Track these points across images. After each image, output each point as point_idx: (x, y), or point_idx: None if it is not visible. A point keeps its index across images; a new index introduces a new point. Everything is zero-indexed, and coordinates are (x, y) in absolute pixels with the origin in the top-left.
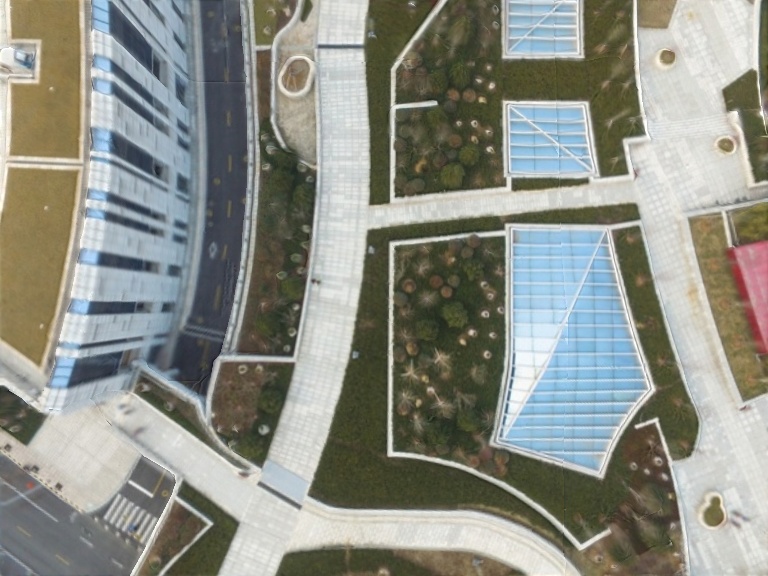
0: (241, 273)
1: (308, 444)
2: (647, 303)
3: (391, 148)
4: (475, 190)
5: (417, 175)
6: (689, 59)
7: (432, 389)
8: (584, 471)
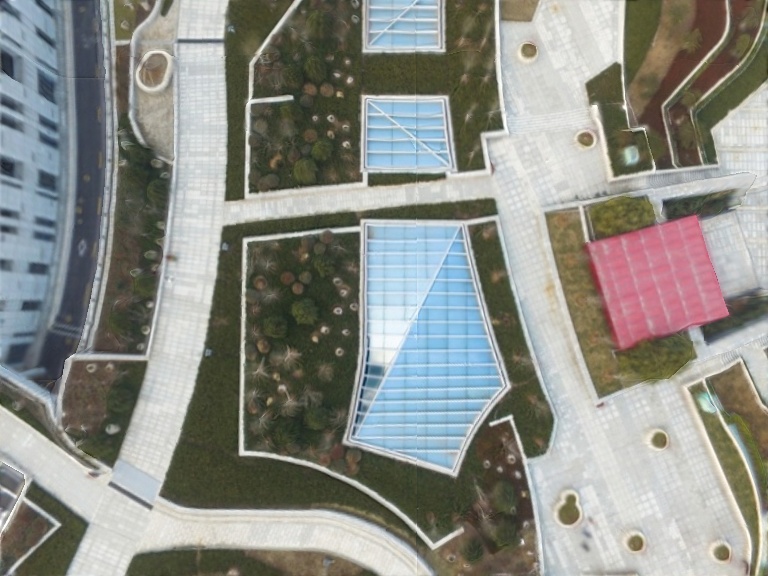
0: (98, 270)
1: (160, 443)
2: (502, 299)
3: (246, 143)
4: (331, 185)
5: (271, 170)
6: (553, 53)
7: (283, 387)
8: (437, 469)
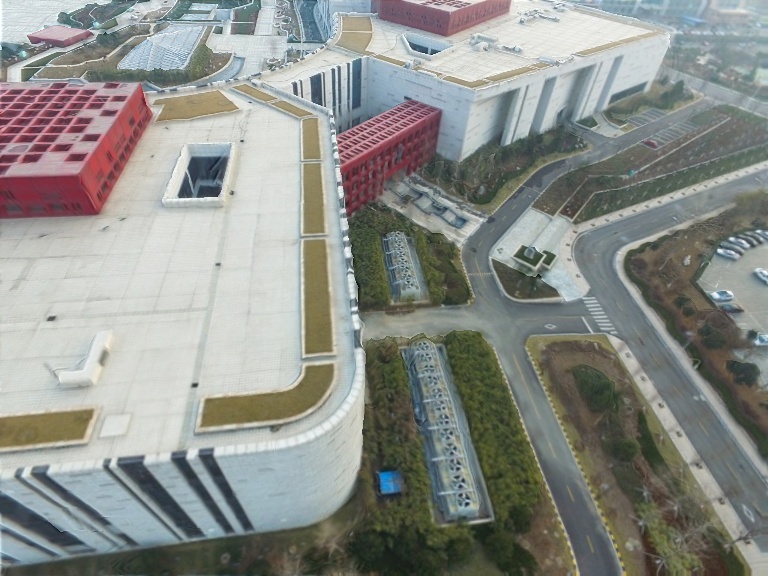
0: None
1: None
2: None
3: None
4: None
5: None
6: (158, 4)
7: None
8: None
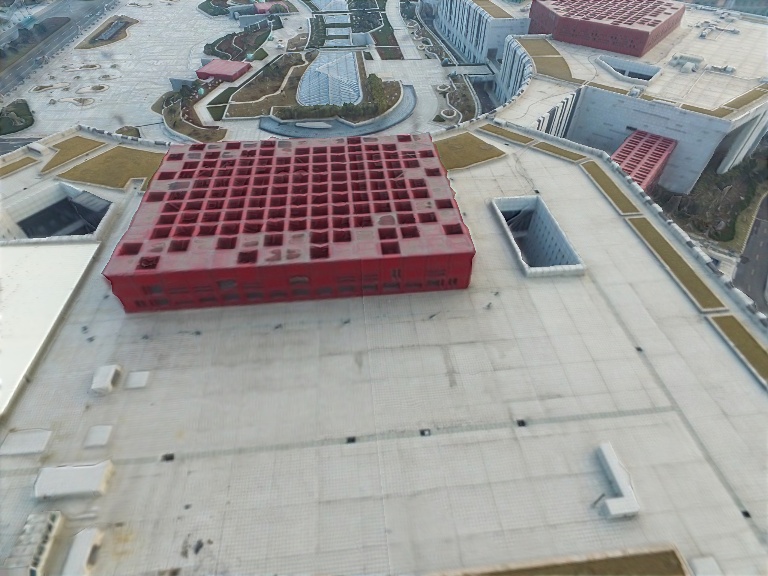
0: None
1: None
2: None
3: None
4: None
5: None
6: None
7: None
8: None
